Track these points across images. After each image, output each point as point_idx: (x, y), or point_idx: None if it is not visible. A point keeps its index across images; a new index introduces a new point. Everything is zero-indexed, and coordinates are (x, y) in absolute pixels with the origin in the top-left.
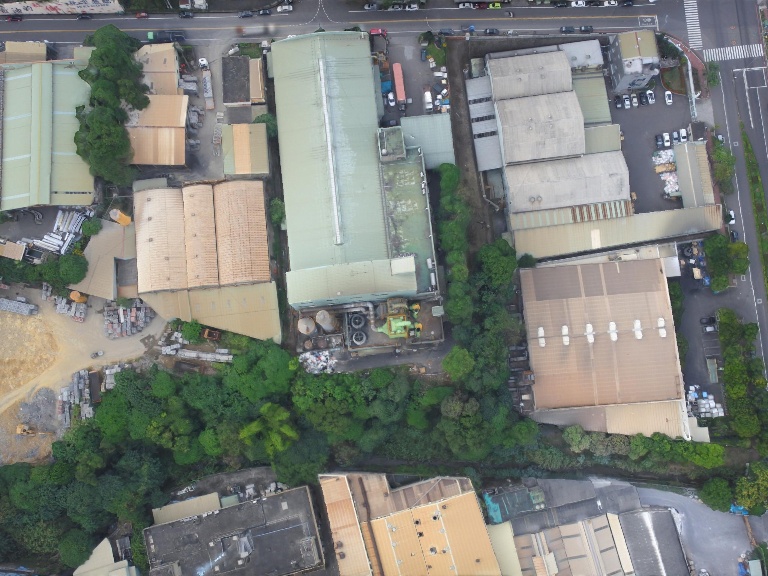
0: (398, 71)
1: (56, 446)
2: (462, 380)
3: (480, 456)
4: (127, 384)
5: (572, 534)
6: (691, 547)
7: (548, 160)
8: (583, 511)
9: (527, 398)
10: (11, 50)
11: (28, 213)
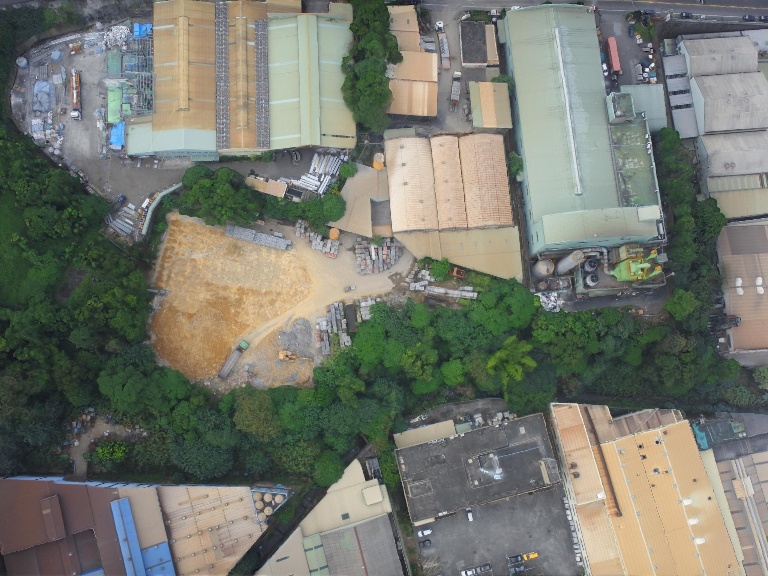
0: (613, 44)
1: (319, 371)
2: None
3: (684, 391)
4: (385, 315)
5: (764, 461)
6: None
7: (738, 132)
8: None
9: (723, 341)
10: (271, 1)
11: (287, 154)
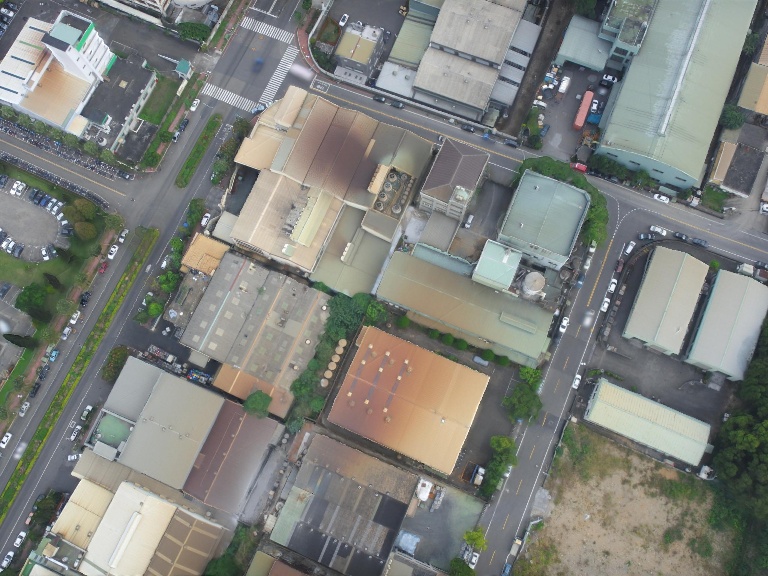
0: (581, 118)
1: None
2: None
3: None
4: None
5: None
6: None
7: None
8: None
9: None
10: None
11: None
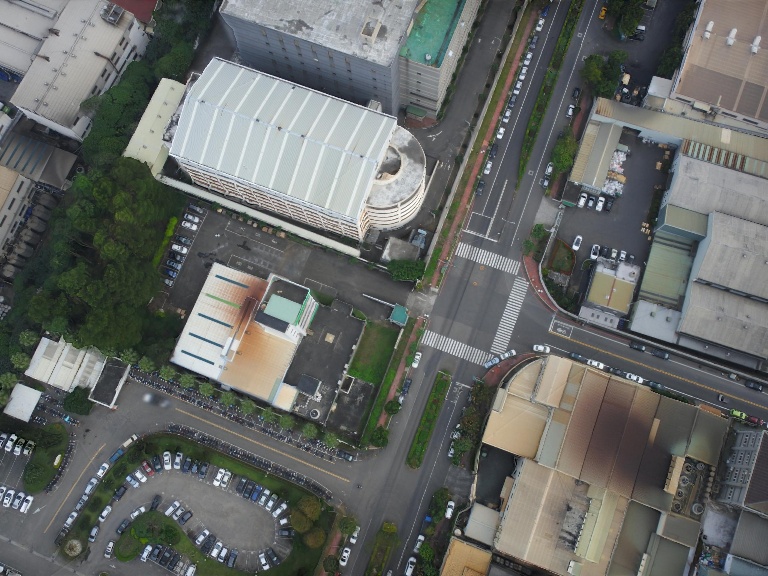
0: None
1: None
2: None
3: None
4: None
5: None
6: None
7: None
8: None
9: None
10: None
11: None
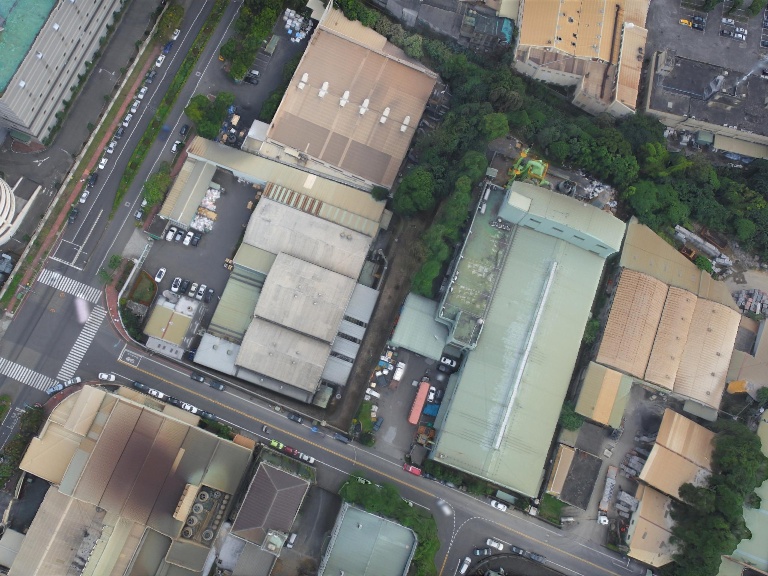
0: (415, 414)
1: None
2: None
3: None
4: None
5: None
6: None
7: None
8: (437, 0)
9: None
10: None
11: None
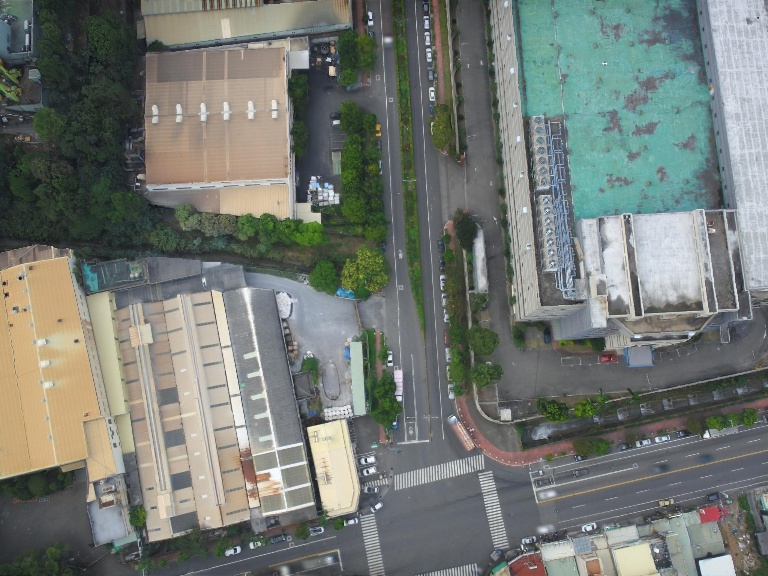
0: None
1: None
2: (58, 145)
3: (89, 231)
4: None
5: (173, 308)
6: (300, 331)
7: None
8: (187, 287)
9: (142, 177)
10: None
11: None
